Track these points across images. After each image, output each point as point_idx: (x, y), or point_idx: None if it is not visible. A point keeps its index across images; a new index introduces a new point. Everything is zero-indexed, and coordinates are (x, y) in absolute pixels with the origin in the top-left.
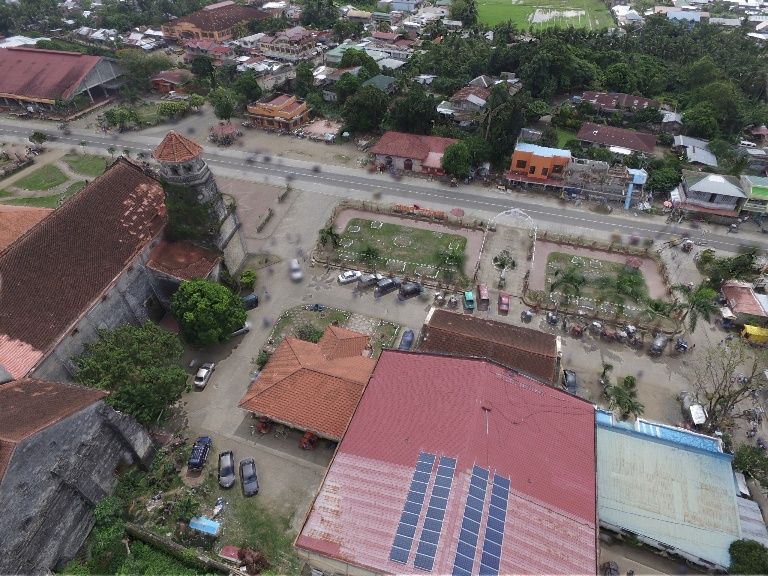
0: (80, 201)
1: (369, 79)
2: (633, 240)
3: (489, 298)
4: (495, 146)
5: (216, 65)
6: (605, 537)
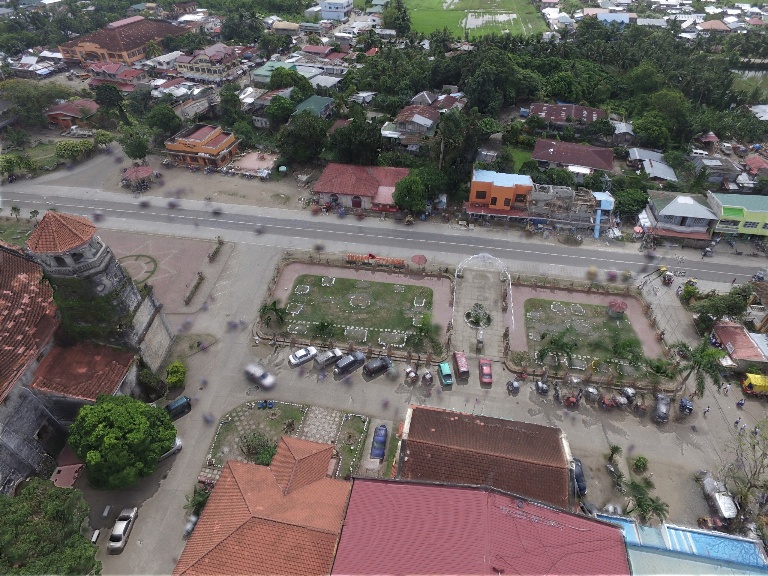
0: None
1: (303, 101)
2: (610, 276)
3: (468, 367)
4: (450, 175)
5: (127, 91)
6: None
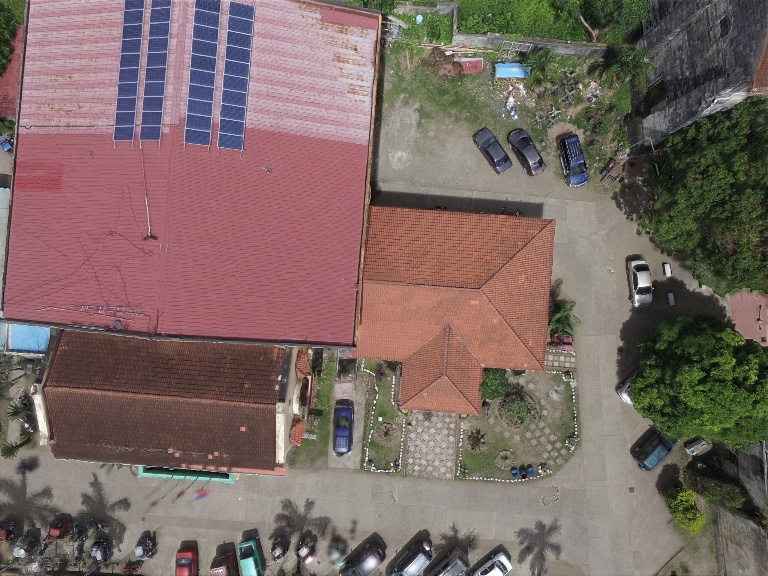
0: None
1: None
2: None
3: None
4: None
5: None
6: None
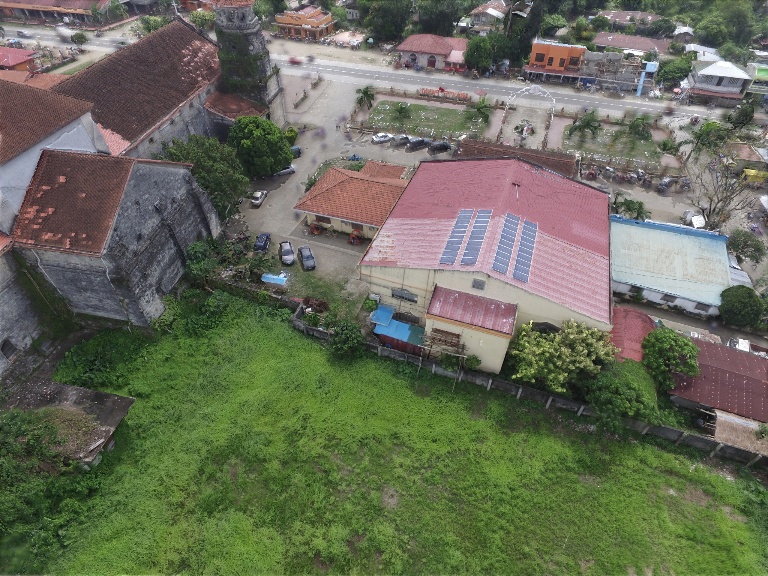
0: (146, 42)
1: None
2: (644, 116)
3: None
4: (515, 44)
5: None
6: (615, 298)
